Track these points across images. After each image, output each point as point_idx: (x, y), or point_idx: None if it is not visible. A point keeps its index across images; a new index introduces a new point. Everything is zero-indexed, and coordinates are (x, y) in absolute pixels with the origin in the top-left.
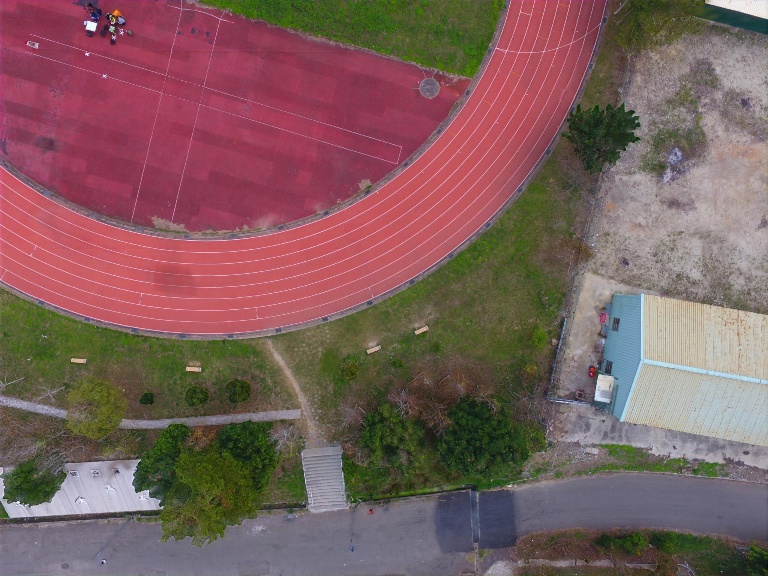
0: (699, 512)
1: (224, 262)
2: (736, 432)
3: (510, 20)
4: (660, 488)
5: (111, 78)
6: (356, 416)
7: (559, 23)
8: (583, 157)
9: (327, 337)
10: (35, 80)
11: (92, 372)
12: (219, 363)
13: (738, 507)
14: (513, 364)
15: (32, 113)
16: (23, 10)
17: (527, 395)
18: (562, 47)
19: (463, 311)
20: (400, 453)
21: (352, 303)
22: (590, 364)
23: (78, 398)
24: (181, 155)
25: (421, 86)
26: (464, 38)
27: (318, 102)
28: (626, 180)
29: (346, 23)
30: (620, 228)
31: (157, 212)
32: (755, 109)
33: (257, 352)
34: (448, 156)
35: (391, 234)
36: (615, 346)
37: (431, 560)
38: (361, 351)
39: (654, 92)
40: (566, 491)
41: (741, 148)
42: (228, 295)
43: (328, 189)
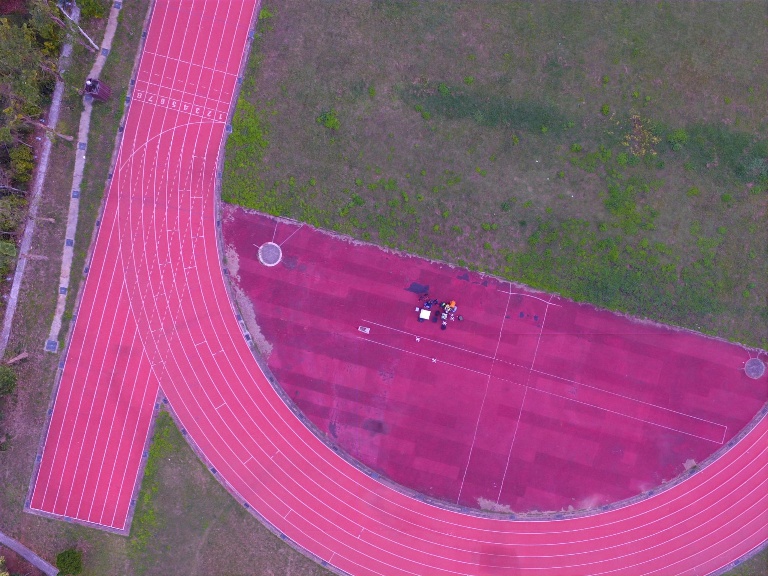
0: None
1: (549, 543)
2: None
3: None
4: None
5: (440, 361)
6: None
7: None
8: None
9: None
10: (366, 364)
11: None
12: None
13: None
14: None
15: (362, 397)
16: (355, 296)
17: None
18: None
19: None
20: None
21: None
22: None
23: None
24: (508, 437)
25: (746, 366)
26: None
27: (644, 383)
28: None
29: (672, 305)
30: None
31: (483, 493)
32: None
33: None
34: None
35: (716, 514)
36: None
37: None
38: None
39: None
40: None
41: None
42: None
43: (653, 469)
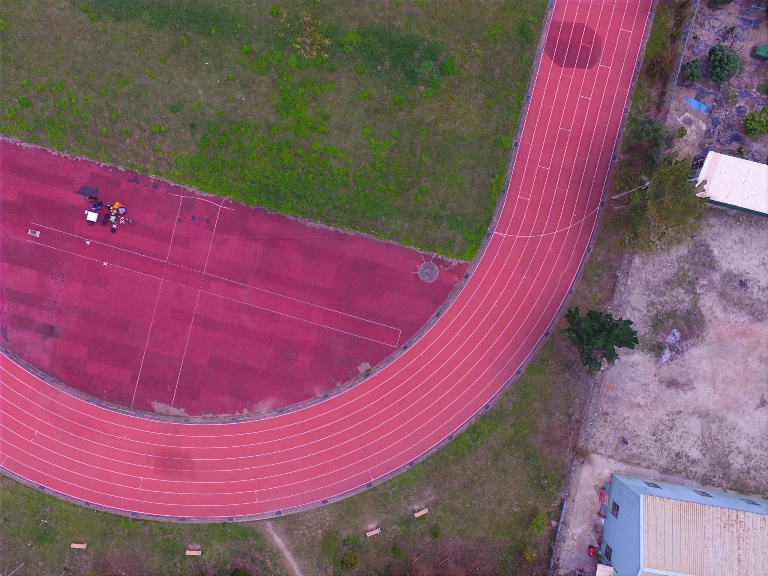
0: None
1: (224, 446)
2: None
3: (508, 204)
4: None
5: (112, 265)
6: None
7: (557, 207)
8: (582, 354)
9: (327, 519)
10: (36, 268)
11: (92, 556)
12: (219, 546)
13: None
14: (513, 546)
15: (33, 300)
16: (25, 199)
17: None
18: (560, 231)
19: (462, 493)
20: None
21: (352, 486)
22: (590, 543)
23: None
24: (181, 340)
25: (420, 270)
26: (463, 223)
27: (318, 287)
28: (625, 360)
29: (345, 209)
30: (619, 408)
31: (157, 397)
32: (753, 290)
33: (257, 535)
34: (447, 339)
35: (390, 417)
36: (614, 534)
37: None
38: (361, 533)
39: (652, 273)
40: None
41: (739, 328)
42: (228, 479)
43: (328, 372)
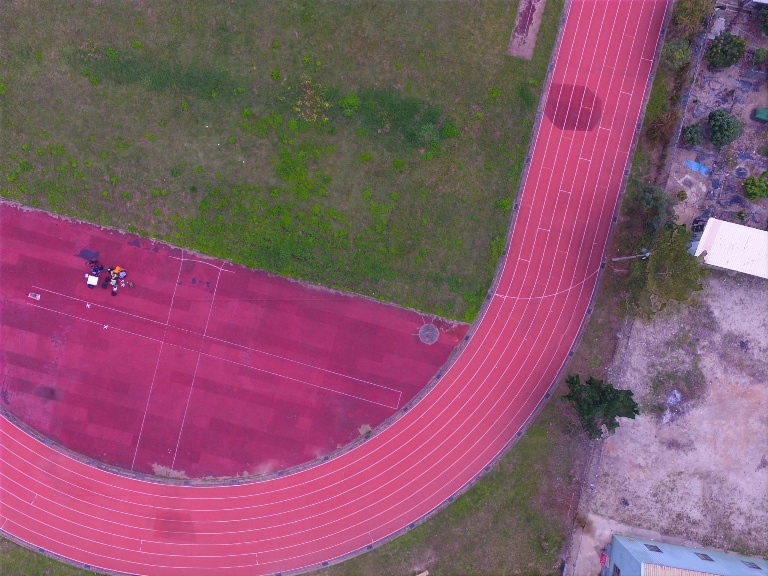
0: None
1: (224, 508)
2: None
3: (509, 266)
4: None
5: (112, 328)
6: None
7: (557, 269)
8: (582, 421)
9: None
10: (37, 331)
11: None
12: None
13: None
14: None
15: (33, 363)
16: (25, 262)
17: None
18: (561, 293)
19: (463, 555)
20: None
21: (352, 548)
22: None
23: None
24: (181, 403)
25: (420, 332)
26: (463, 285)
27: (318, 349)
28: (625, 421)
29: (346, 271)
30: (620, 469)
31: (157, 459)
32: (754, 351)
33: None
34: (448, 401)
35: (391, 479)
36: None
37: None
38: None
39: (653, 334)
40: None
41: (740, 389)
42: (228, 541)
43: (328, 435)
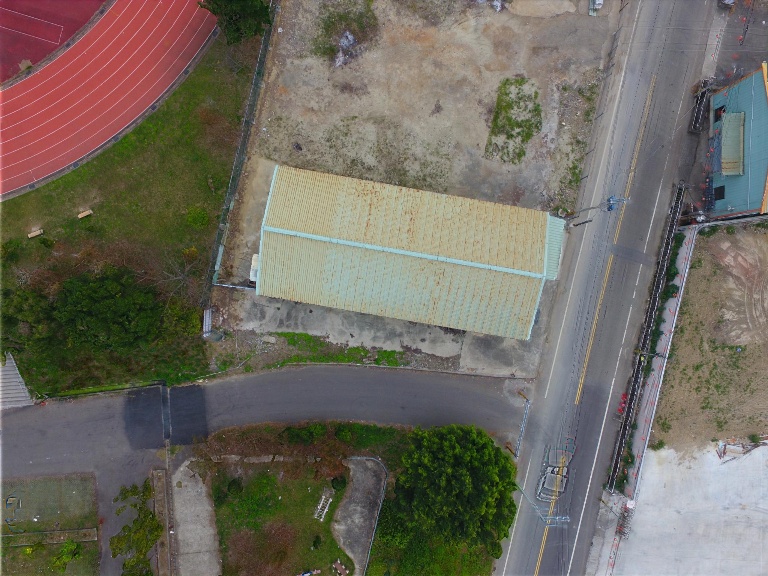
0: (383, 403)
1: None
2: (372, 305)
3: None
4: (346, 380)
5: None
6: None
7: None
8: (222, 29)
9: None
10: None
11: None
12: None
13: (421, 397)
14: (180, 249)
15: None
16: None
17: (178, 274)
18: None
19: (129, 195)
20: (20, 324)
21: (13, 186)
22: None
23: None
24: None
25: None
26: None
27: None
28: (298, 64)
29: None
30: (292, 112)
31: None
32: None
33: None
34: (111, 36)
35: (53, 116)
36: None
37: (121, 457)
38: (24, 236)
39: None
40: (256, 385)
41: (413, 32)
42: None
43: None
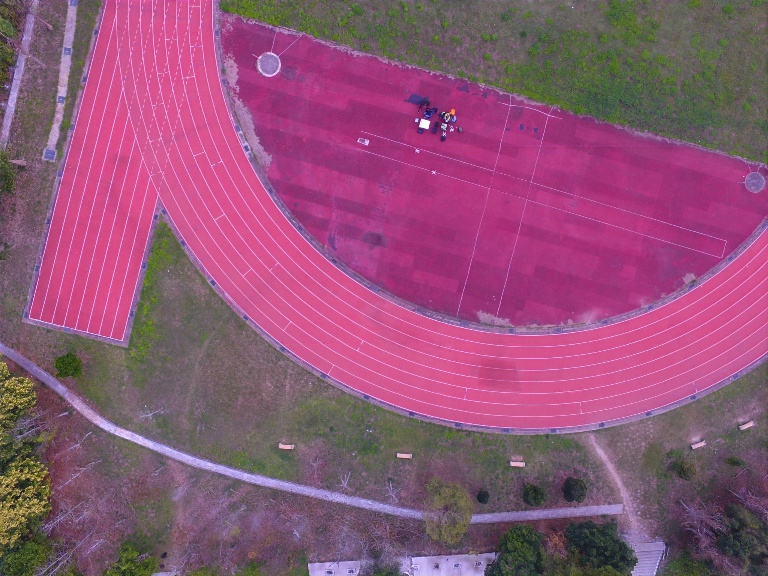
0: None
1: (548, 356)
2: None
3: None
4: None
5: (439, 174)
6: (679, 511)
7: None
8: None
9: (650, 432)
10: (365, 176)
11: (416, 467)
12: (542, 458)
13: None
14: None
15: (361, 209)
16: (355, 107)
17: None
18: None
19: None
20: (767, 562)
21: (676, 398)
22: None
23: (440, 504)
24: (507, 250)
25: (746, 180)
26: None
27: (644, 197)
28: None
29: (673, 118)
30: None
31: (482, 307)
32: None
33: (580, 447)
34: None
35: (715, 328)
36: None
37: None
38: (684, 446)
39: None
40: None
41: None
42: (552, 390)
43: (652, 283)
